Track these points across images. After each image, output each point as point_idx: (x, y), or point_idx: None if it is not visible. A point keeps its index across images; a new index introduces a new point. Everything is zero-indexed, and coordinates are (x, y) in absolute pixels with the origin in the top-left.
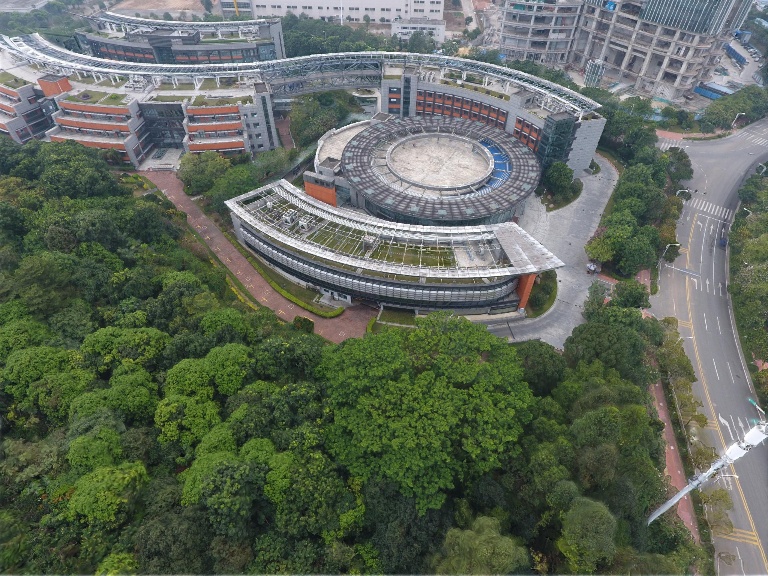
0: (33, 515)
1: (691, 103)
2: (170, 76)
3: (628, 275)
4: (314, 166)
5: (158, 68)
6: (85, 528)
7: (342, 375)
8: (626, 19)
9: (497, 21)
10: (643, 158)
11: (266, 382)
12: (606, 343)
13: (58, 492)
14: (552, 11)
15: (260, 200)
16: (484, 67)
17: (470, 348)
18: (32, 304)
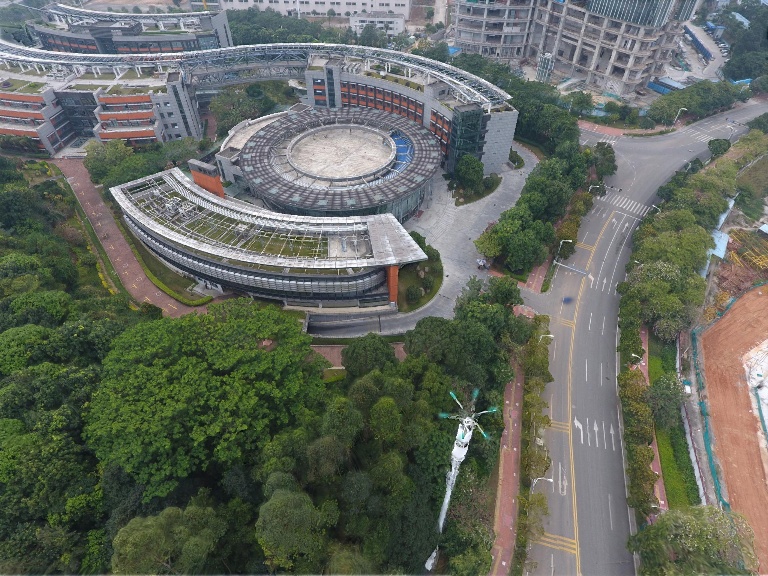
0: None
1: (642, 99)
2: (89, 65)
3: (520, 272)
4: None
5: (82, 57)
6: None
7: (108, 358)
8: (578, 12)
9: None
10: (560, 152)
11: (50, 364)
12: (434, 337)
13: None
14: (505, 4)
15: (151, 188)
16: (408, 58)
17: (248, 335)
18: None
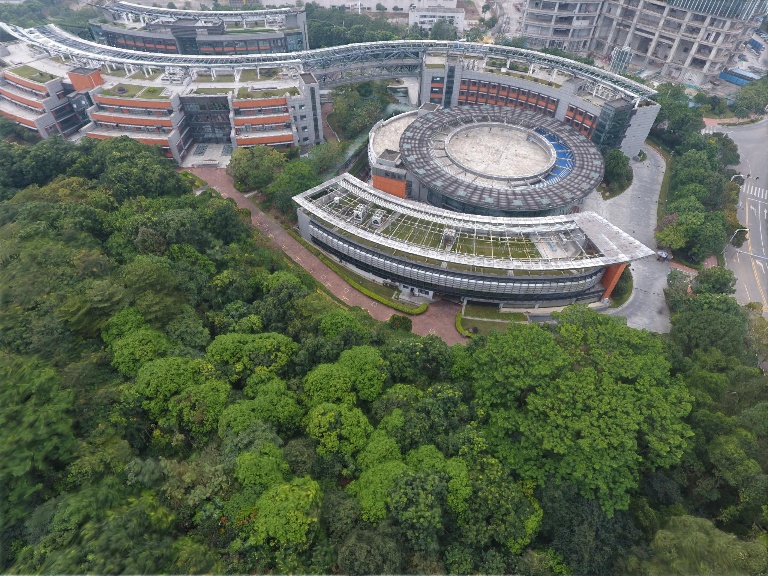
0: (219, 541)
1: (718, 89)
2: (210, 67)
3: (697, 261)
4: (369, 159)
5: (194, 59)
6: (277, 551)
7: (498, 375)
8: (652, 5)
9: (520, 8)
10: (695, 144)
11: (407, 385)
12: (722, 331)
13: (242, 514)
14: None
15: None
16: (528, 54)
17: (620, 342)
18: (149, 312)
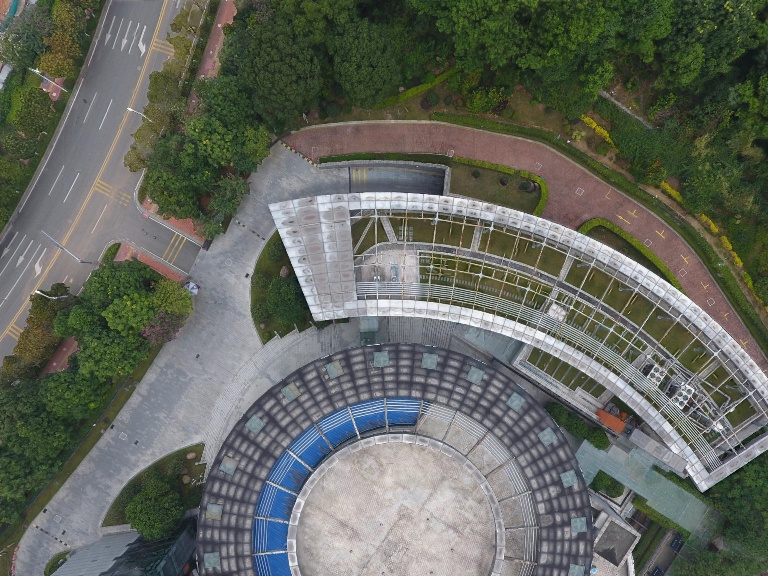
0: None
1: None
2: None
3: None
4: None
5: None
6: None
7: None
8: None
9: None
10: None
11: None
12: (281, 36)
13: None
14: None
15: None
16: None
17: None
18: None
